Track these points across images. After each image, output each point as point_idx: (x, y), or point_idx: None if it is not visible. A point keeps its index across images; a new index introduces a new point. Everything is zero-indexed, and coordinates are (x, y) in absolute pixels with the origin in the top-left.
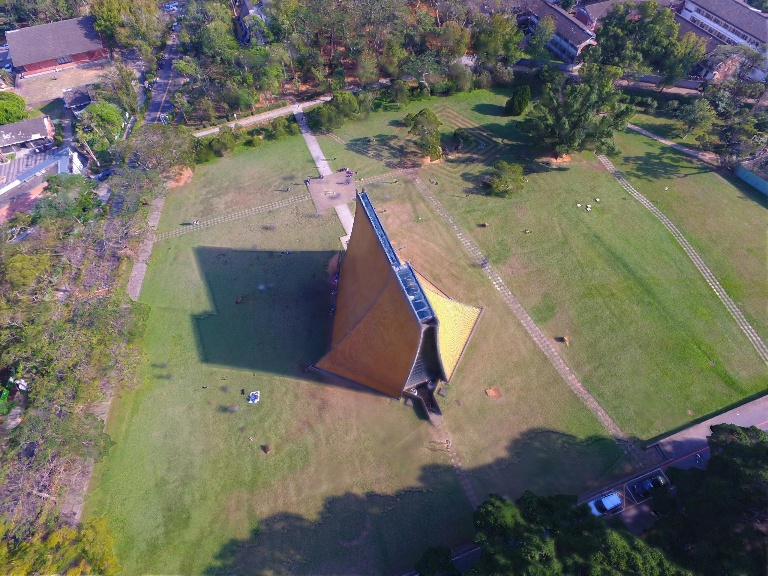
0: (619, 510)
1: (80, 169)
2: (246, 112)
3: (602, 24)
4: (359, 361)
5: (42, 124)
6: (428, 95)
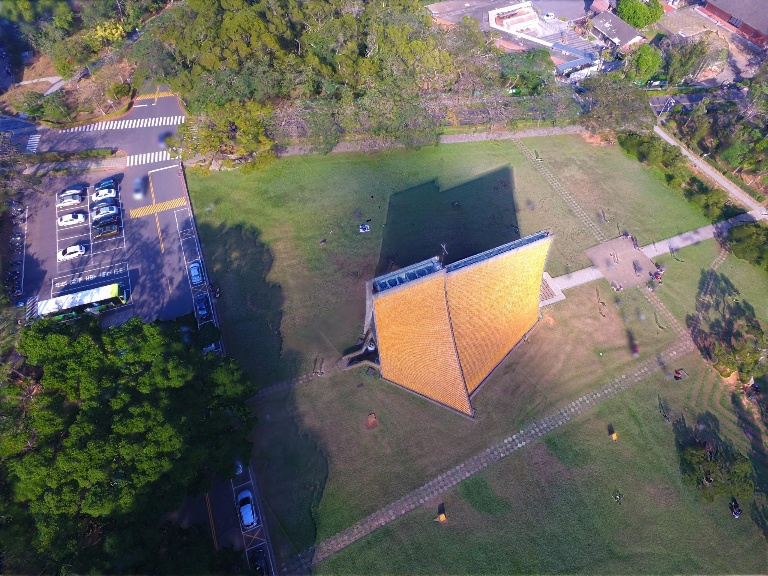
0: None
1: (588, 77)
2: (723, 166)
3: None
4: None
5: (631, 37)
6: None
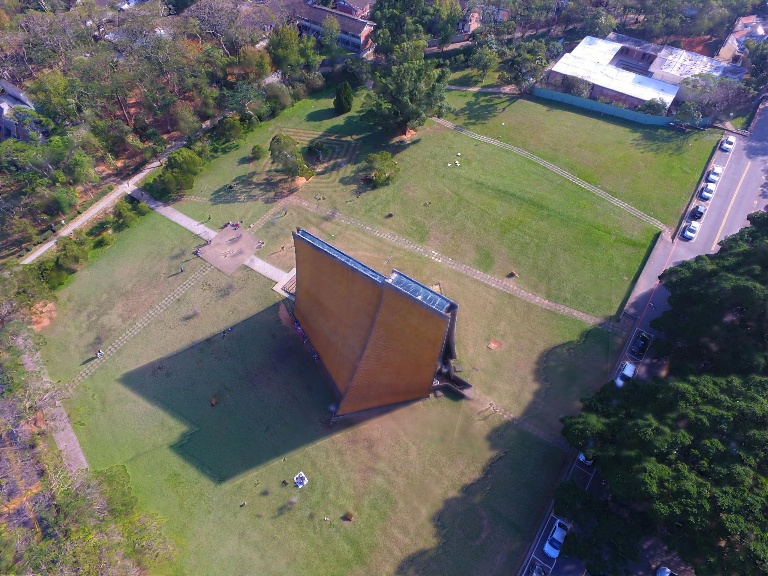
0: (635, 373)
1: None
2: (71, 214)
3: (376, 10)
4: (380, 385)
5: None
6: (258, 123)
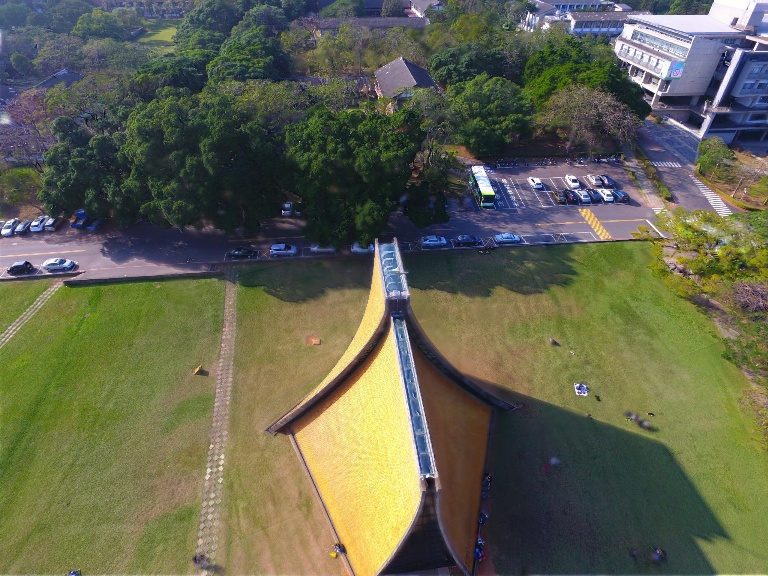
0: None
1: None
2: None
3: None
4: None
5: None
6: None
